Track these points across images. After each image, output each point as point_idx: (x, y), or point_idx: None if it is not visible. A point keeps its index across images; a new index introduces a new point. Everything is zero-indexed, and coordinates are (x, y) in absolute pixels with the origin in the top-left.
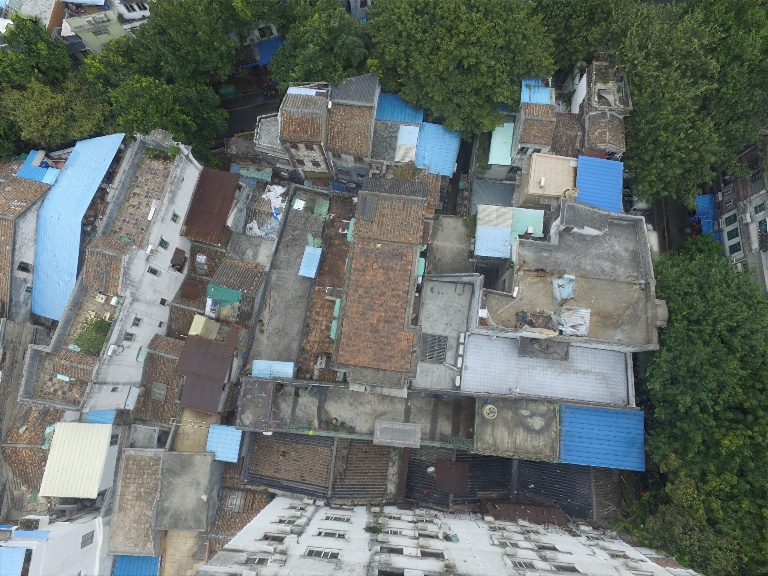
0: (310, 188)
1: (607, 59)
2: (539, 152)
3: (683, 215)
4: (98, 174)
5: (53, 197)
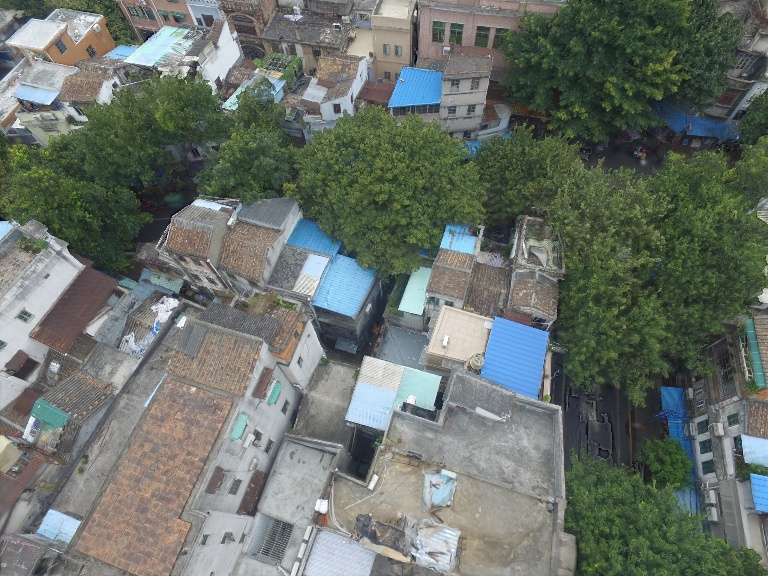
0: (200, 306)
1: (544, 215)
2: (452, 305)
3: (652, 408)
4: None
5: None
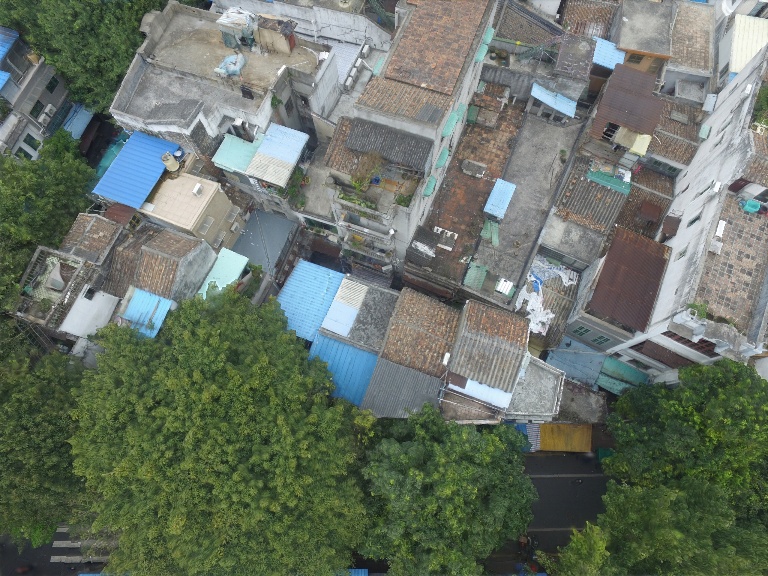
0: (488, 299)
1: (23, 333)
2: None
3: None
4: None
5: None
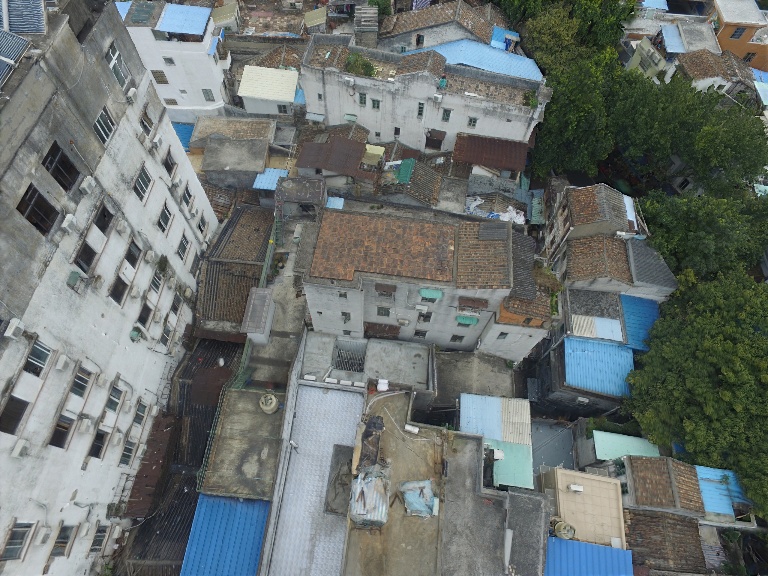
0: None
1: None
2: (624, 492)
3: None
4: (506, 72)
5: (480, 46)
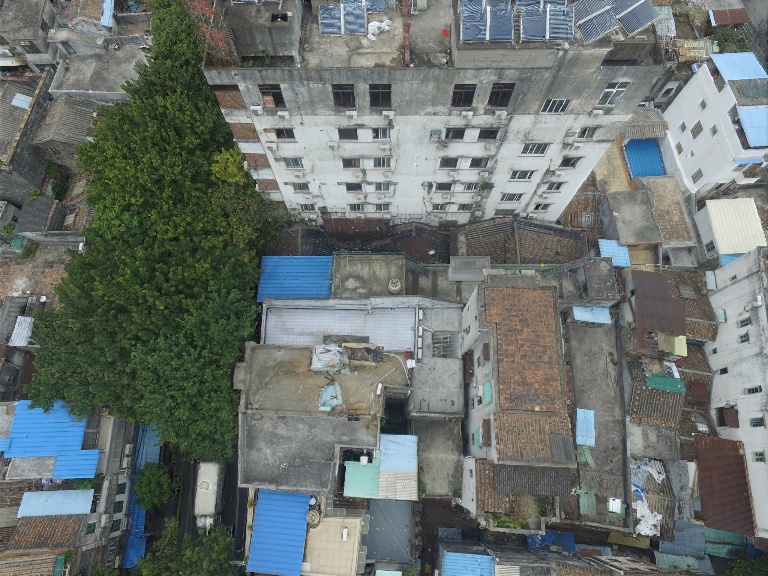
0: (610, 527)
1: None
2: None
3: None
4: None
5: None
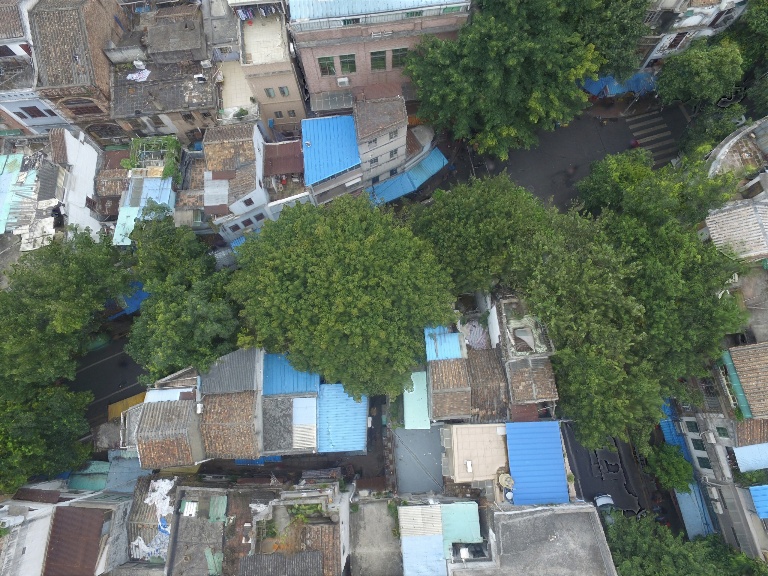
0: (199, 489)
1: None
2: None
3: None
4: None
5: None
